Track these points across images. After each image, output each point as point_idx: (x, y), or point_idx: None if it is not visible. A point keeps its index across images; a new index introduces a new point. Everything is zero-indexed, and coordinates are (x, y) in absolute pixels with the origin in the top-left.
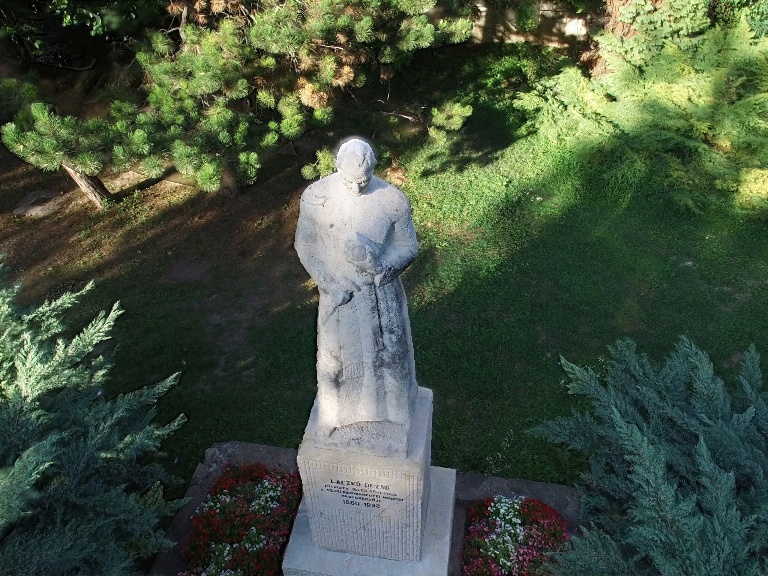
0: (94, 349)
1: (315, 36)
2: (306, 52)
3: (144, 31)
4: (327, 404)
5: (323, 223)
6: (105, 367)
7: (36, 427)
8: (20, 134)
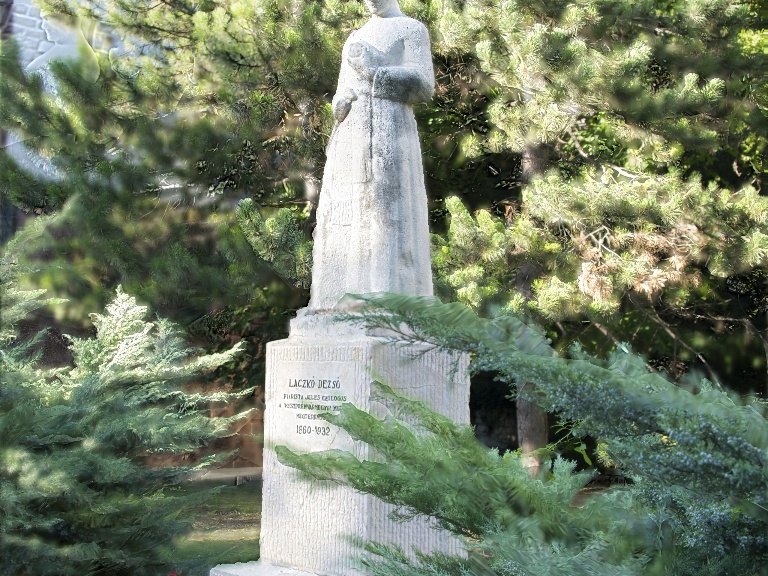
0: (212, 446)
1: (602, 204)
2: (614, 258)
3: (447, 237)
4: (314, 271)
5: (347, 46)
6: (209, 460)
7: (97, 393)
8: (251, 208)
